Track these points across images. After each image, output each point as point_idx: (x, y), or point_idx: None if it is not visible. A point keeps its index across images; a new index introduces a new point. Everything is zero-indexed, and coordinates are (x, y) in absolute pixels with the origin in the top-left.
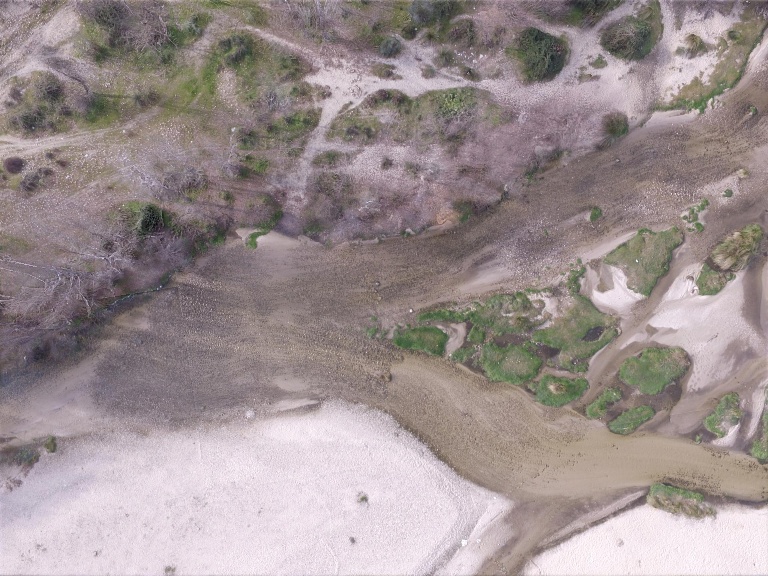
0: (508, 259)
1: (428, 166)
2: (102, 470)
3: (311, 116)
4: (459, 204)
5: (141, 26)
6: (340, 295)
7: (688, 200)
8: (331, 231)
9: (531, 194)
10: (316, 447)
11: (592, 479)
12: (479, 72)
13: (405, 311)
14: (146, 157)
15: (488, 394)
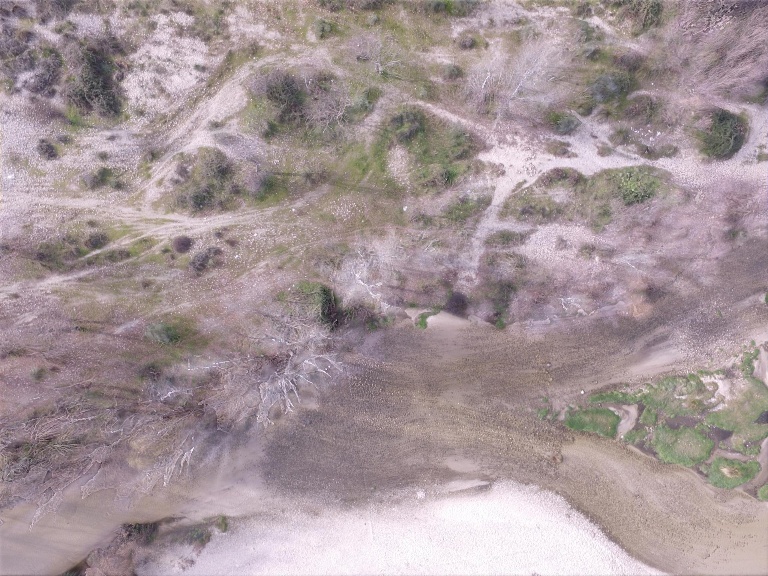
0: (681, 340)
1: (603, 247)
2: (274, 550)
3: (484, 195)
4: (633, 285)
5: (310, 101)
6: (511, 376)
7: None
8: (502, 311)
9: (705, 274)
10: (488, 528)
11: (762, 560)
12: (656, 150)
13: (576, 392)
14: (316, 236)
15: (659, 476)
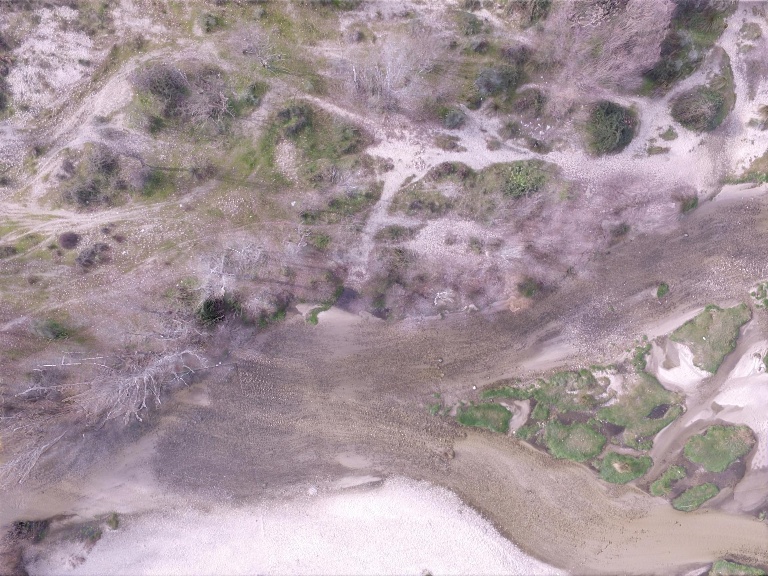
0: (573, 335)
1: (493, 241)
2: (165, 547)
3: (373, 190)
4: (524, 280)
5: (197, 96)
6: (402, 372)
7: (757, 276)
8: (393, 307)
9: (597, 269)
10: (379, 525)
11: (655, 555)
12: (546, 144)
13: (468, 388)
14: (204, 232)
15: (552, 471)
